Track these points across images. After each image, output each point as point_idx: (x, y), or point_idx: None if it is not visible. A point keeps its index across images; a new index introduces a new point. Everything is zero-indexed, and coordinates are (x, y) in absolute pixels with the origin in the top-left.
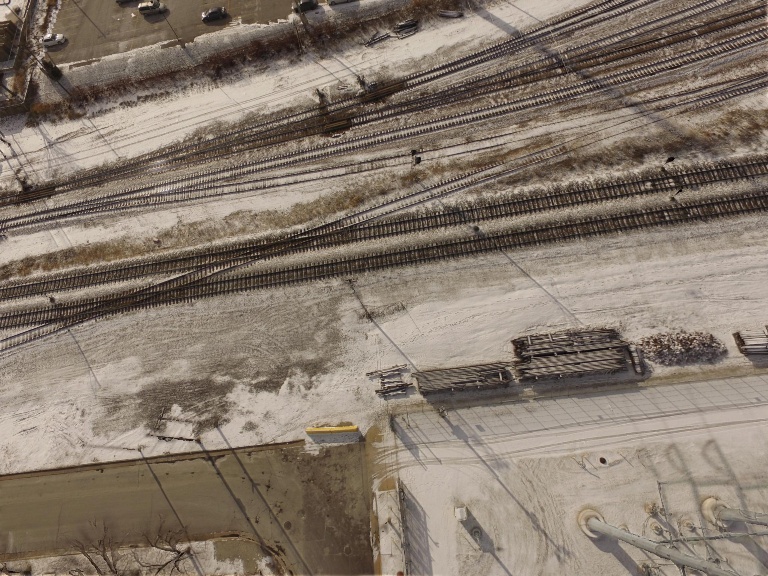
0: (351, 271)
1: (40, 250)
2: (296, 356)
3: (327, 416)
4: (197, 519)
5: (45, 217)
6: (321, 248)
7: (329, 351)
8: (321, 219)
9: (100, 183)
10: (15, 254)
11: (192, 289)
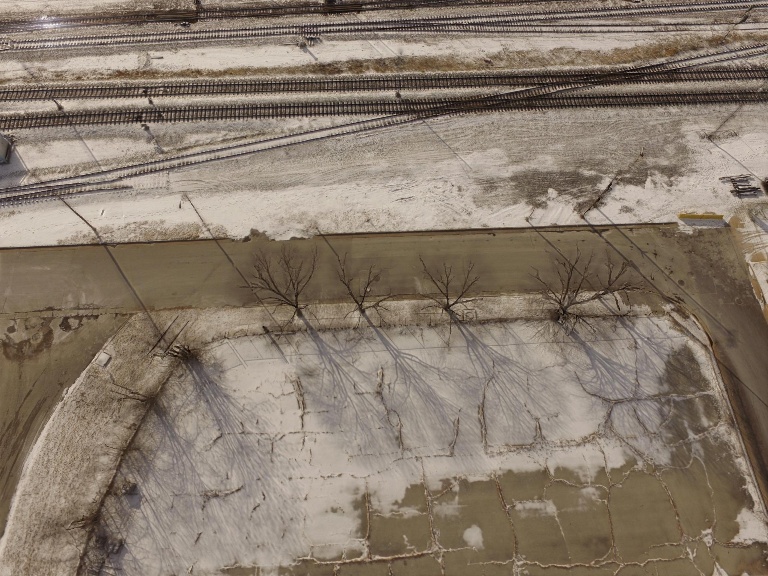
0: (685, 102)
1: (363, 55)
2: (652, 161)
3: (693, 206)
4: (599, 274)
5: (360, 28)
6: (653, 83)
7: (681, 160)
8: (645, 61)
9: (411, 7)
10: (336, 56)
11: (540, 101)
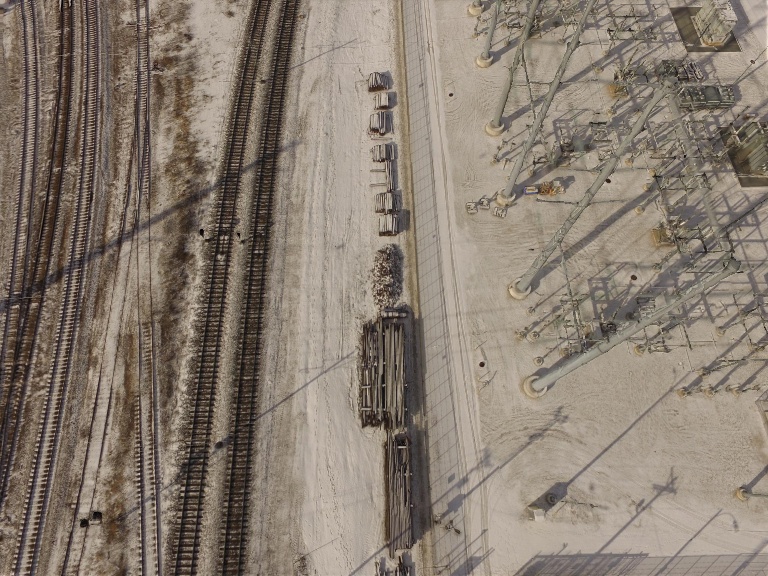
0: None
1: None
2: None
3: None
4: None
5: None
6: None
7: None
8: None
9: None
10: None
11: None
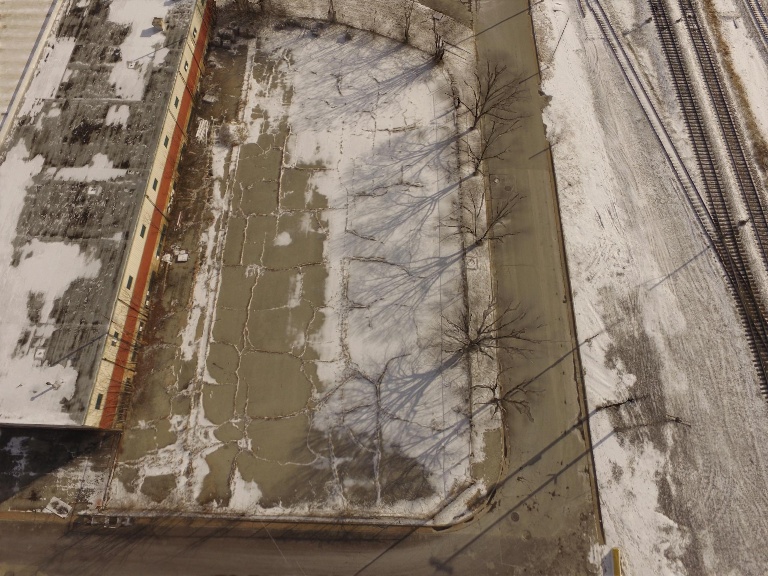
0: None
1: None
2: (706, 539)
3: None
4: None
5: None
6: None
7: None
8: None
9: None
10: None
11: None
